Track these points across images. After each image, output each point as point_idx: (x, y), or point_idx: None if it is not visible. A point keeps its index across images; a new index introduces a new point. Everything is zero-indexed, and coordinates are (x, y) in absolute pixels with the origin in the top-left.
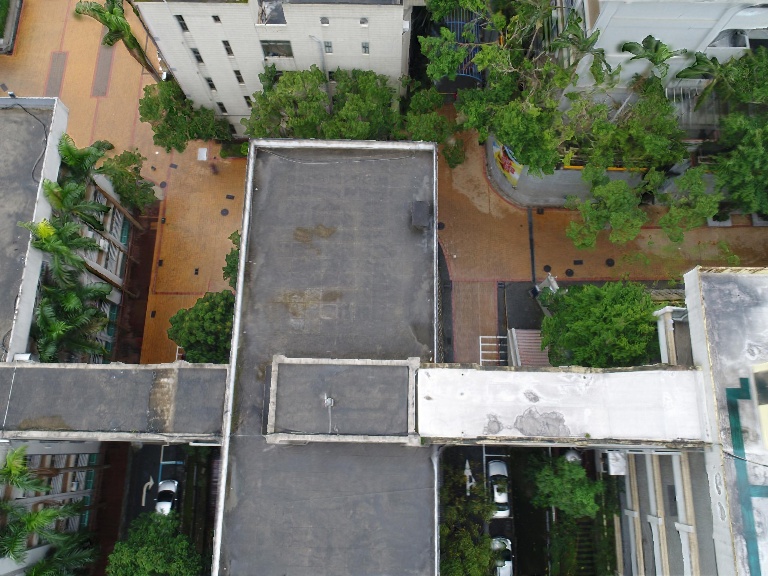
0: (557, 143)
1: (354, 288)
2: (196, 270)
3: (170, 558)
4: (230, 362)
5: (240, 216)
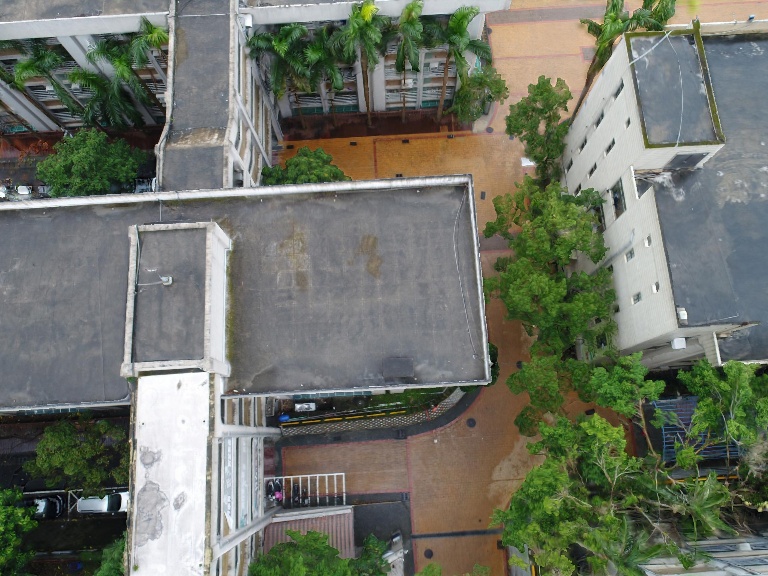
0: (530, 544)
1: (312, 303)
2: (401, 175)
3: (87, 177)
4: (225, 188)
5: None
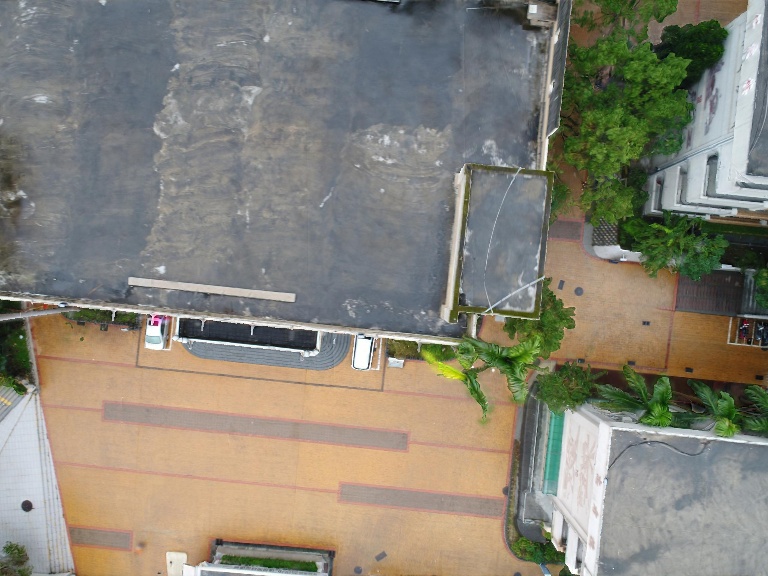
0: None
1: None
2: (644, 324)
3: None
4: None
5: (586, 274)
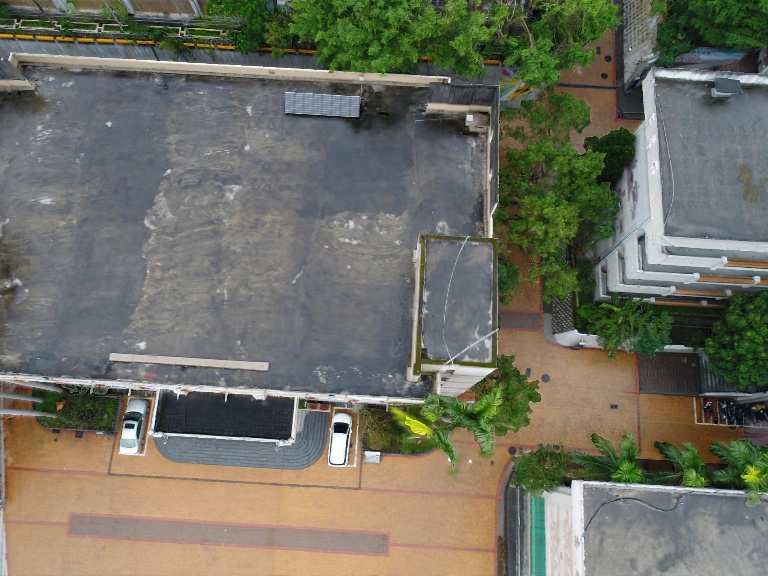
0: None
1: None
2: (612, 408)
3: None
4: None
5: (550, 361)
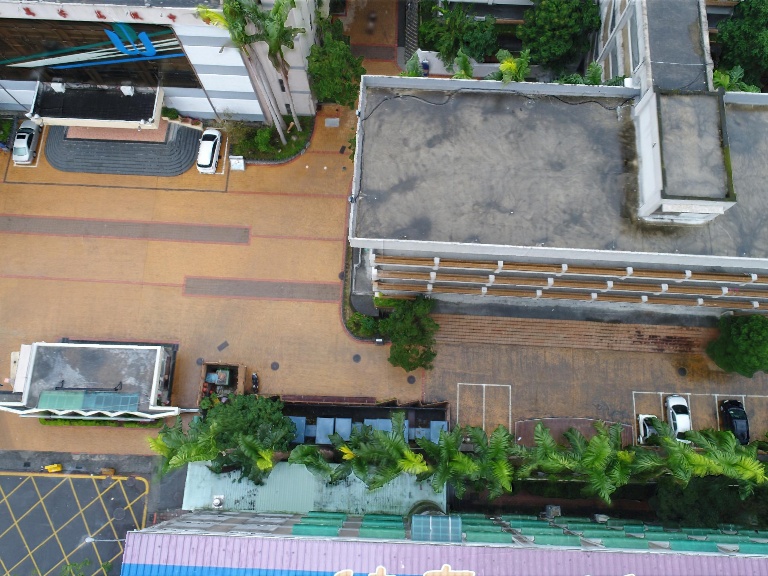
0: None
1: None
2: None
3: None
4: None
5: None
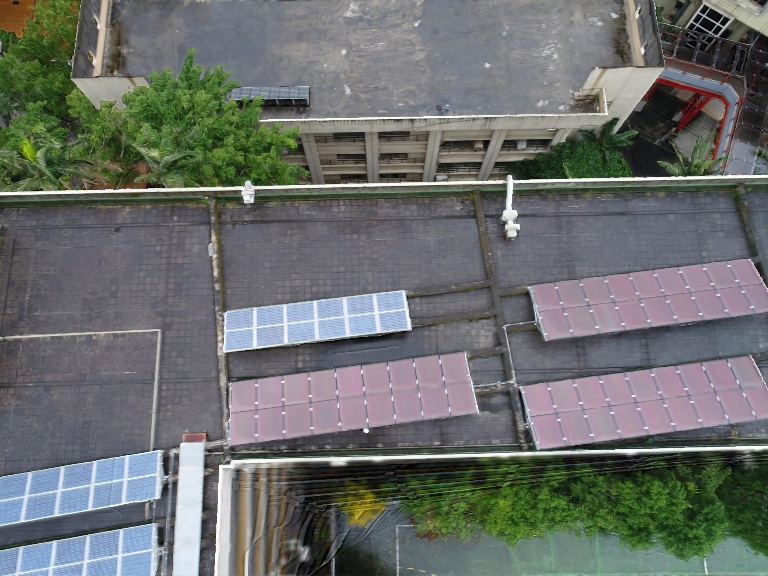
0: None
1: None
2: None
3: None
4: None
5: None
